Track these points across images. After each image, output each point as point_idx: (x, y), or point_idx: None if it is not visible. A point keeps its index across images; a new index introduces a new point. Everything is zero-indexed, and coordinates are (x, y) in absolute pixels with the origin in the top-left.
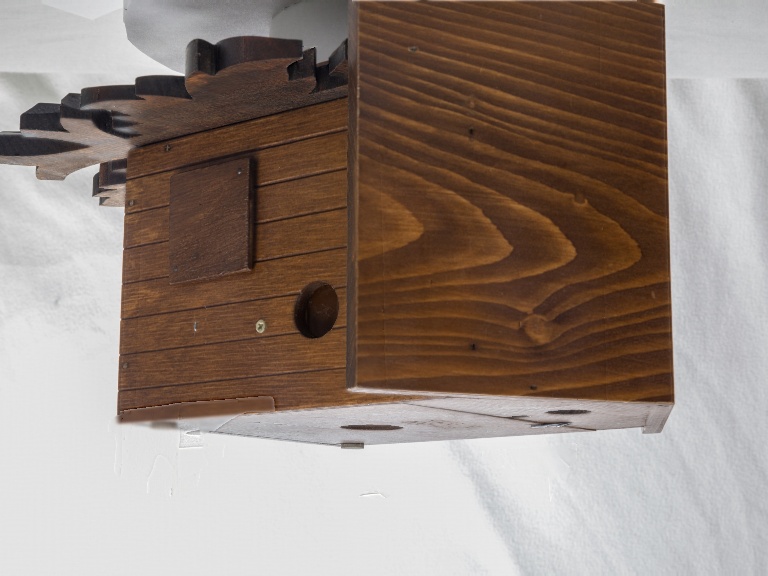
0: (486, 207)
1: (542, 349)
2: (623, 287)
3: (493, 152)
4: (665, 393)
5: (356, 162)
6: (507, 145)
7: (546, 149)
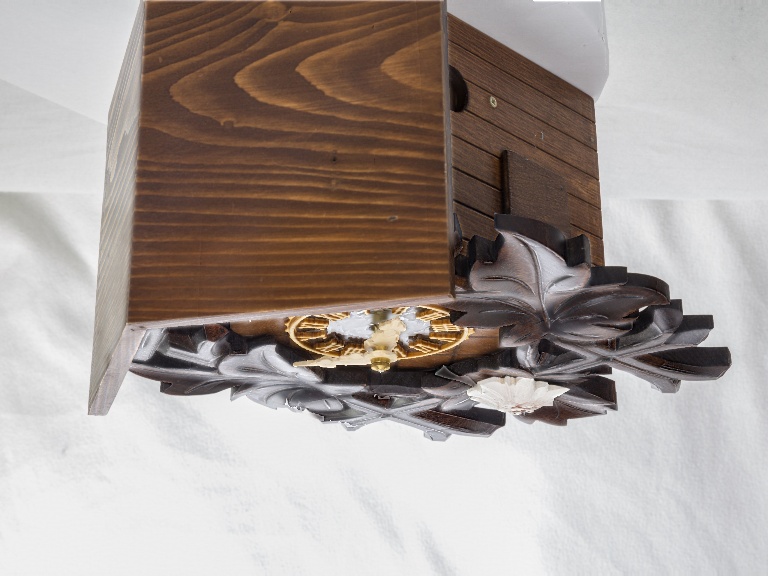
0: (321, 98)
1: None
2: (190, 60)
3: (313, 146)
4: None
5: (445, 110)
6: (299, 155)
7: (260, 160)
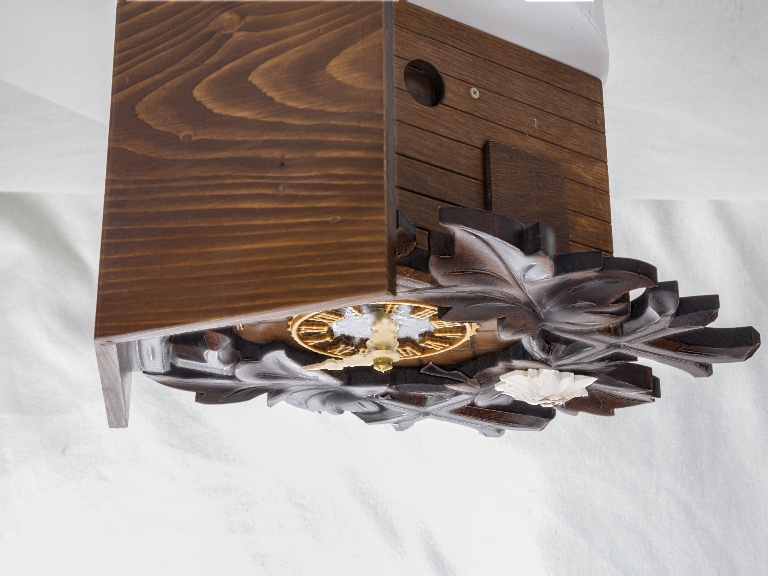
0: (271, 105)
1: (227, 8)
2: (154, 78)
3: (263, 153)
4: (124, 7)
5: (386, 107)
6: (250, 163)
7: (215, 170)
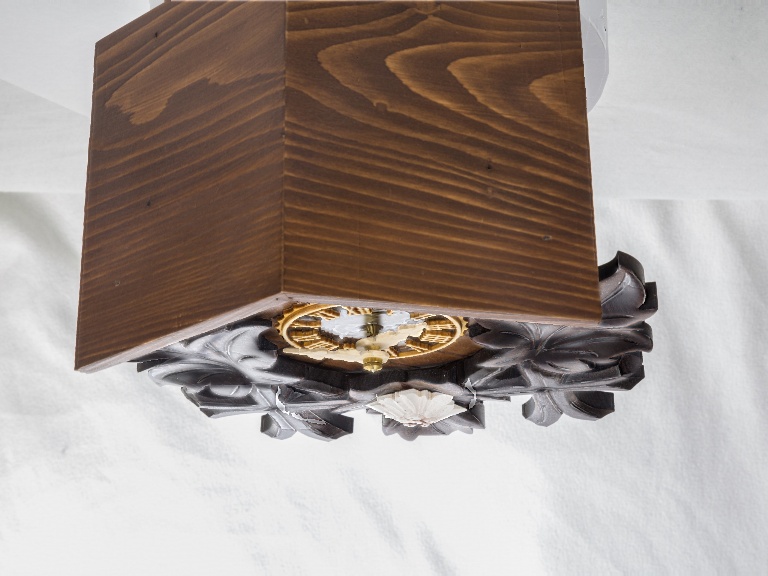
0: (474, 103)
1: None
2: (338, 30)
3: (468, 149)
4: None
5: None
6: (455, 155)
7: (416, 151)
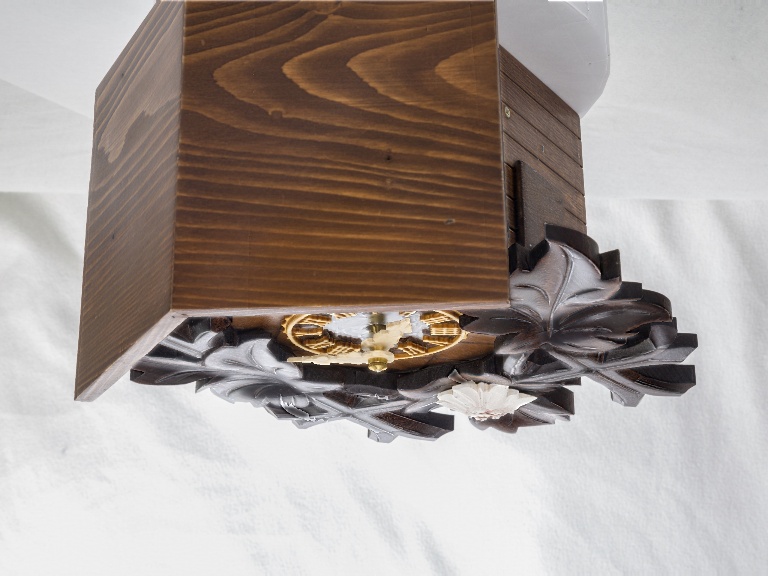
0: (374, 95)
1: None
2: (235, 46)
3: (367, 143)
4: None
5: None
6: (352, 151)
7: (311, 153)
